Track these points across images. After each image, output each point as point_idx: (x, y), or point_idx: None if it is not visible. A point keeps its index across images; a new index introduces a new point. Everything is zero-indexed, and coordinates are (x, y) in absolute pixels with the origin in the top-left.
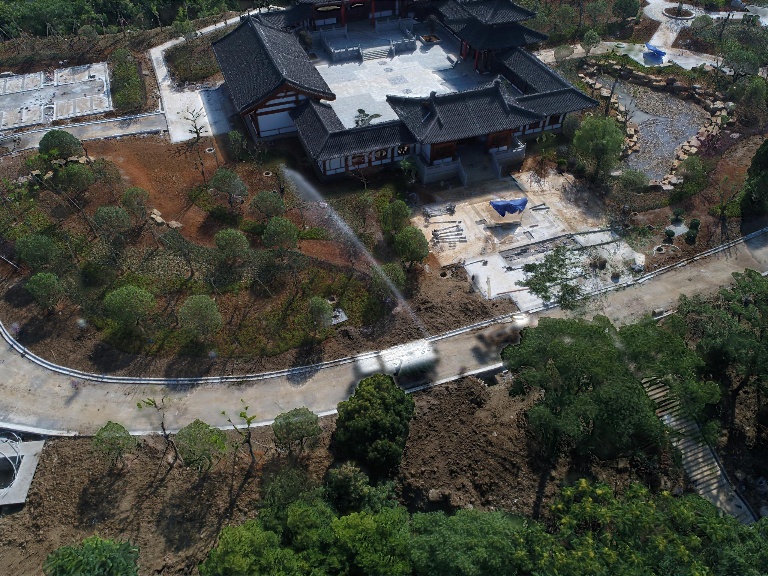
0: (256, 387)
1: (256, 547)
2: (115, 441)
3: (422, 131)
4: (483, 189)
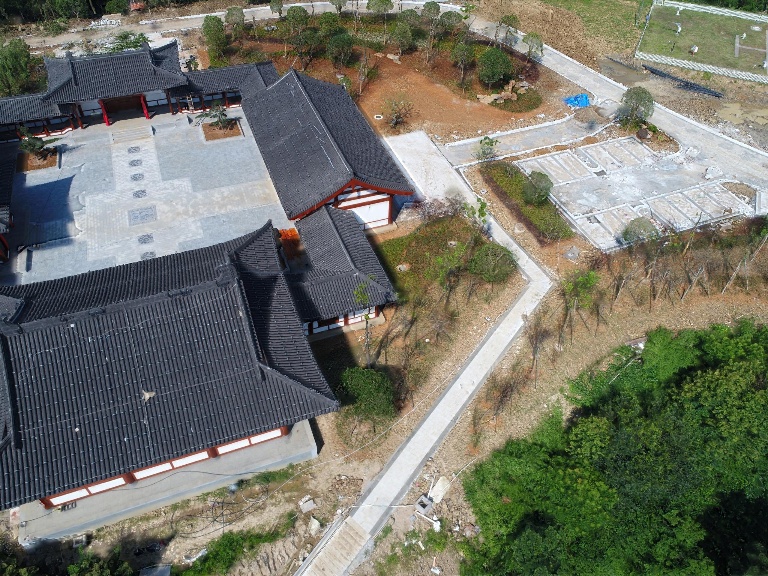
0: None
1: None
2: None
3: (170, 55)
4: None
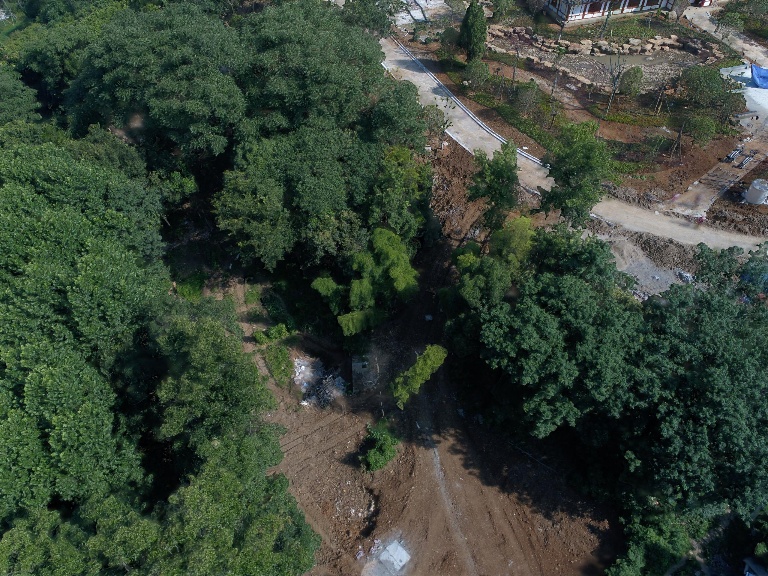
0: None
1: None
2: None
3: None
4: None
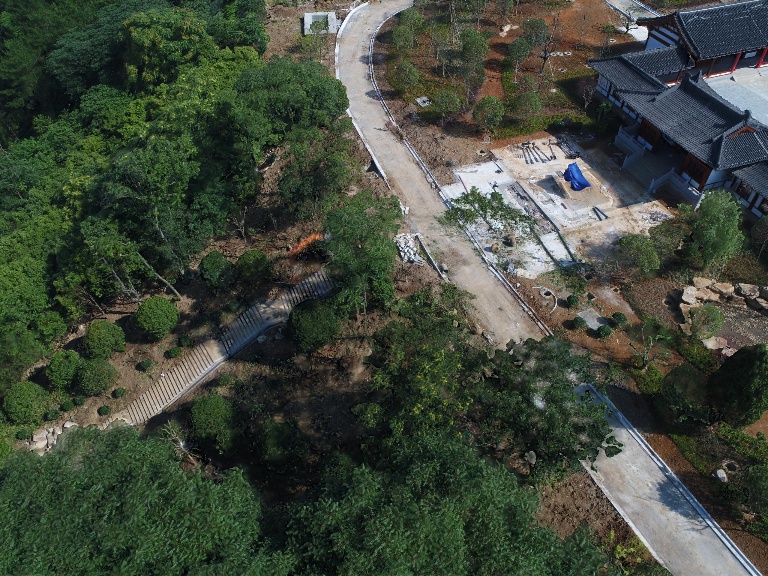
0: (366, 81)
1: (246, 56)
2: (313, 26)
3: None
4: (619, 179)
